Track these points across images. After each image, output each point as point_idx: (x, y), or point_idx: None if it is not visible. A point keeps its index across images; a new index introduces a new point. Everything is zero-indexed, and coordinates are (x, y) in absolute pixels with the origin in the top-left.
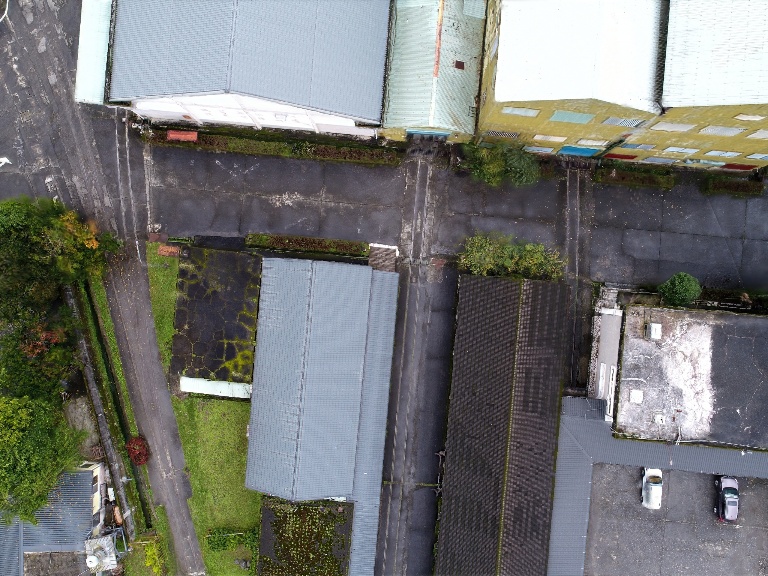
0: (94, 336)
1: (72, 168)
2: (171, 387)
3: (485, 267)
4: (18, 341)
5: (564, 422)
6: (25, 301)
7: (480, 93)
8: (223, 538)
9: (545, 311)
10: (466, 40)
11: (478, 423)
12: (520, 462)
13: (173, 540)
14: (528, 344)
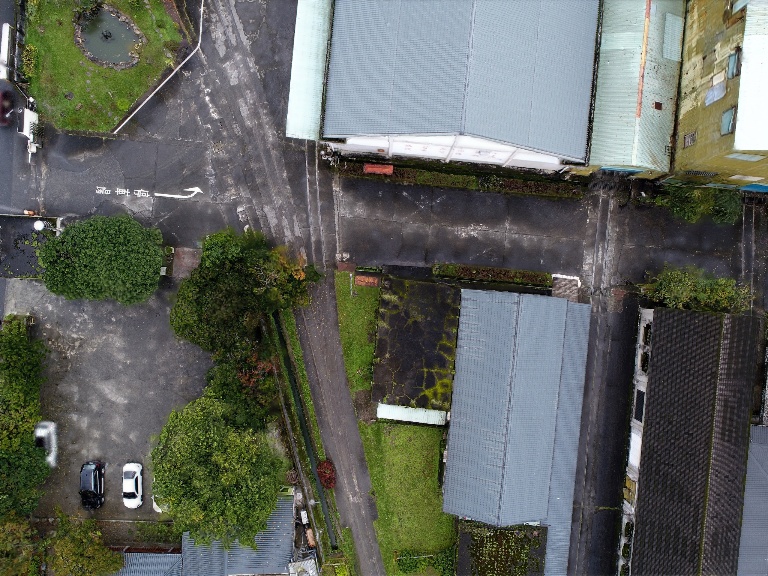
0: (282, 362)
1: (263, 198)
2: (358, 412)
3: (681, 301)
4: (237, 370)
5: (751, 450)
6: (241, 331)
7: (676, 133)
8: (414, 560)
9: (740, 344)
10: (664, 82)
11: (675, 451)
12: (718, 489)
13: (359, 561)
14: (726, 376)
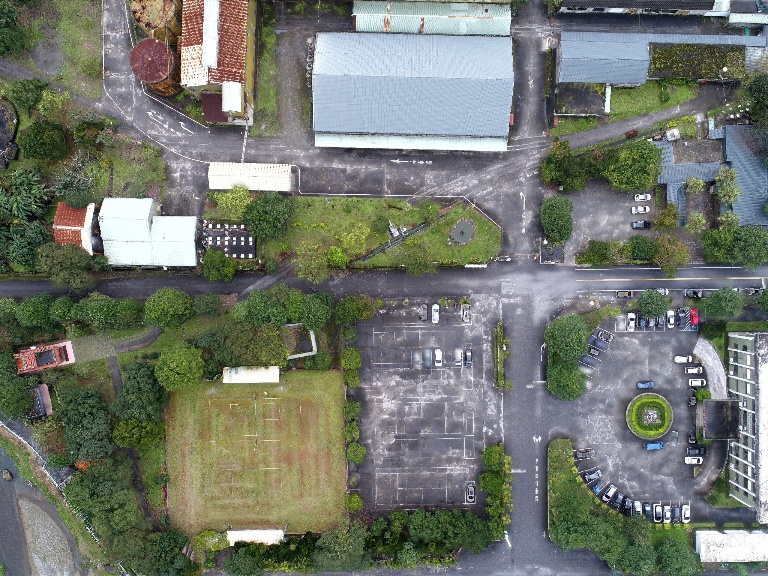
0: None
1: (523, 167)
2: (606, 123)
3: None
4: None
5: None
6: None
7: (496, 3)
8: (664, 95)
9: None
10: (477, 9)
11: None
12: None
13: (666, 119)
14: None
